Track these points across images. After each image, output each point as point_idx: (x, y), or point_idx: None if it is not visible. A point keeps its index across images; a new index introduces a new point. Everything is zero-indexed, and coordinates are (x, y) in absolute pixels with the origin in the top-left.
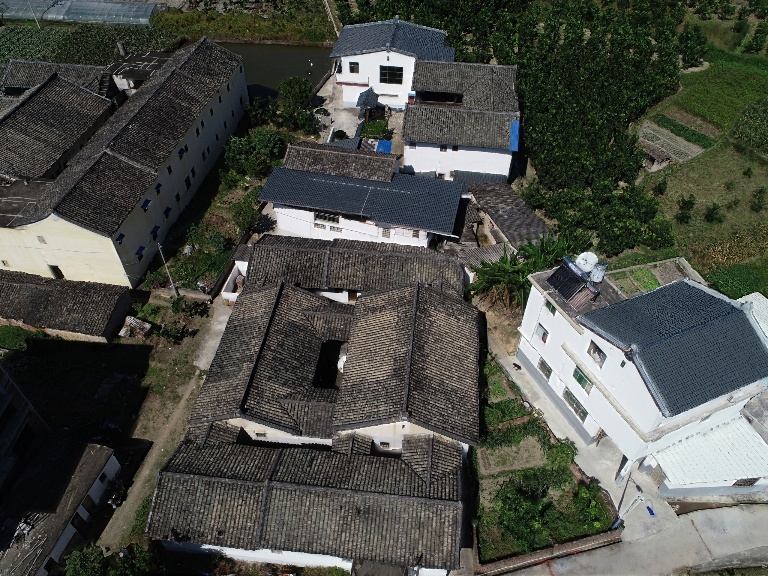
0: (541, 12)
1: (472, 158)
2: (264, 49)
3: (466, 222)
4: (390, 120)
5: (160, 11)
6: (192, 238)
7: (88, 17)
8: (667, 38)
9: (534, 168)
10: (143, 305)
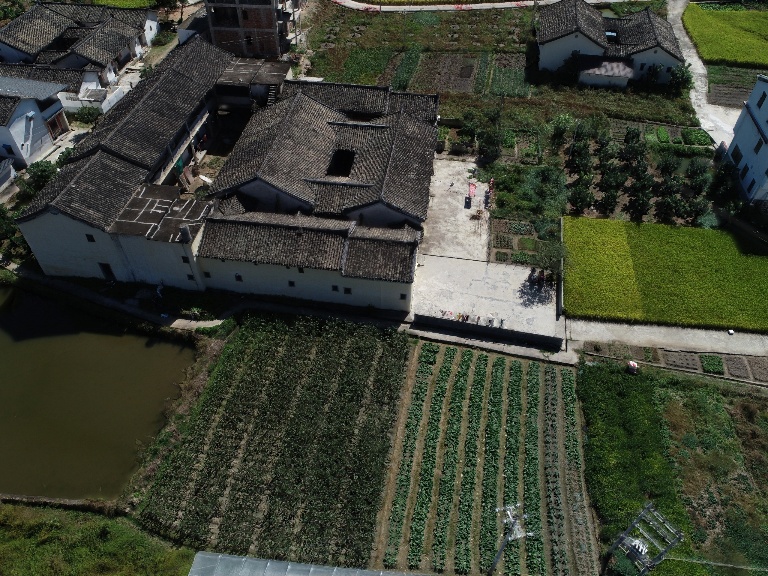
0: None
1: None
2: None
3: None
4: None
5: None
6: None
7: (361, 572)
8: None
9: None
10: None
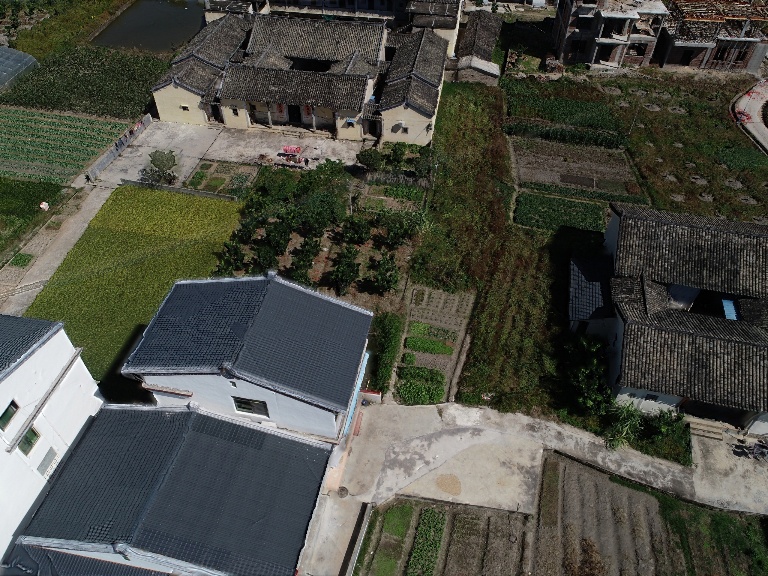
0: None
1: None
2: None
3: None
4: None
5: None
6: None
7: None
8: None
9: None
10: None
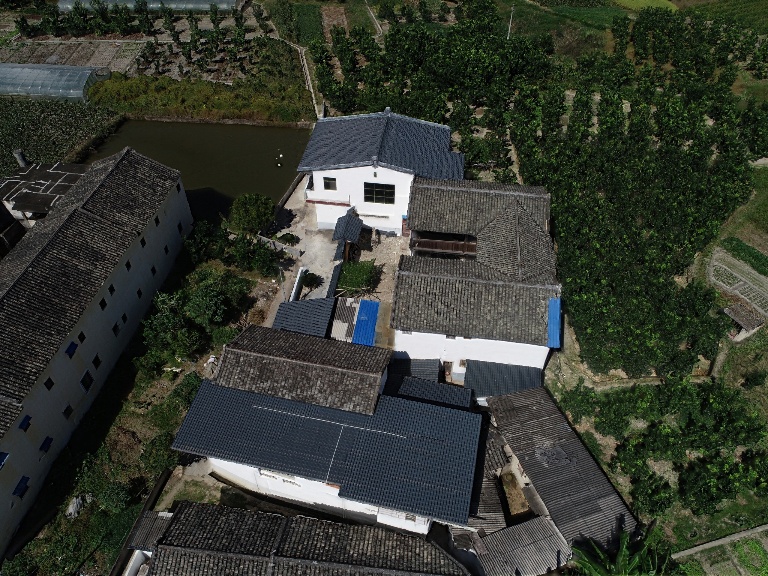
0: (565, 72)
1: (492, 347)
2: (224, 129)
3: (486, 470)
4: (378, 250)
5: (101, 75)
6: (84, 480)
7: (8, 88)
8: (730, 120)
9: (575, 337)
10: None
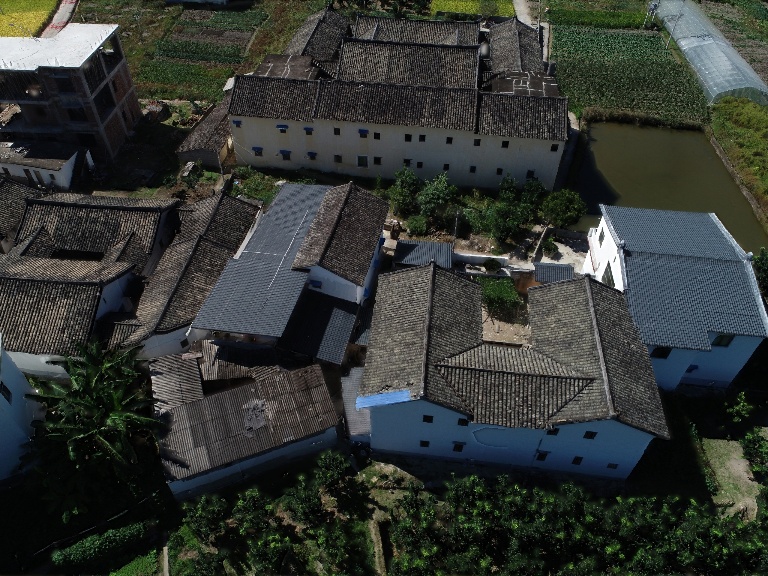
0: None
1: None
2: (738, 196)
3: (254, 368)
4: None
5: None
6: None
7: (695, 60)
8: None
9: None
10: (219, 172)
